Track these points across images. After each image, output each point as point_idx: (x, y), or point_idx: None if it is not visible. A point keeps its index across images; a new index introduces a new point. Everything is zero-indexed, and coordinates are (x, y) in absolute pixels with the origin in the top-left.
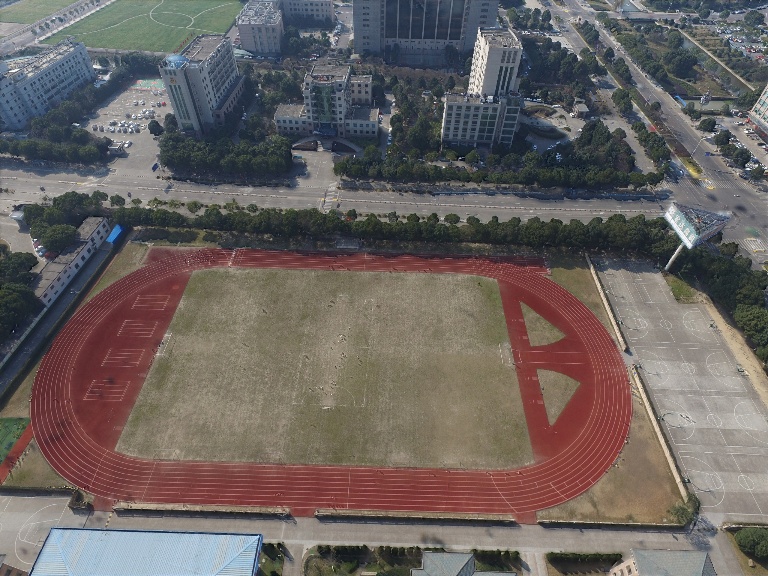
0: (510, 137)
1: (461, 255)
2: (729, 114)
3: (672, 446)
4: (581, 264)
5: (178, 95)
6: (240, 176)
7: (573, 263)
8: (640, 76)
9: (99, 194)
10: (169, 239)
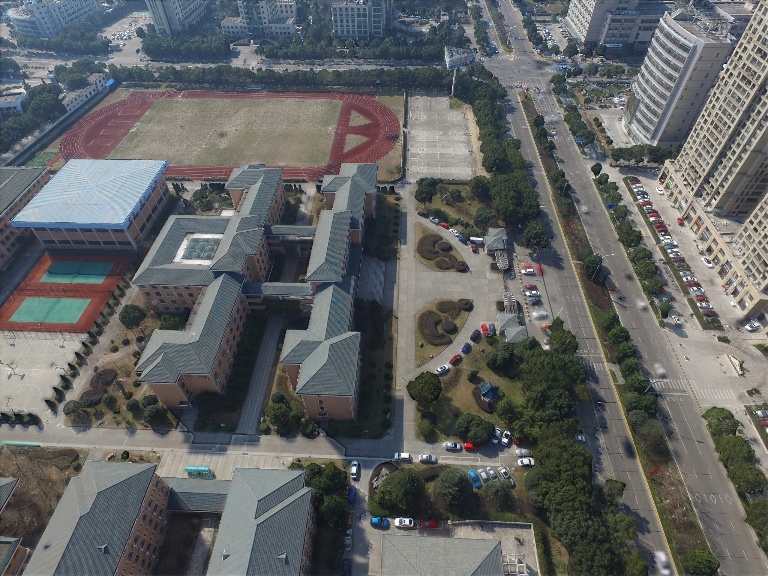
0: (380, 31)
1: (325, 91)
2: (557, 21)
3: (407, 159)
4: (400, 94)
5: (154, 7)
6: (193, 57)
7: (395, 94)
8: (507, 2)
9: (101, 63)
10: (144, 87)
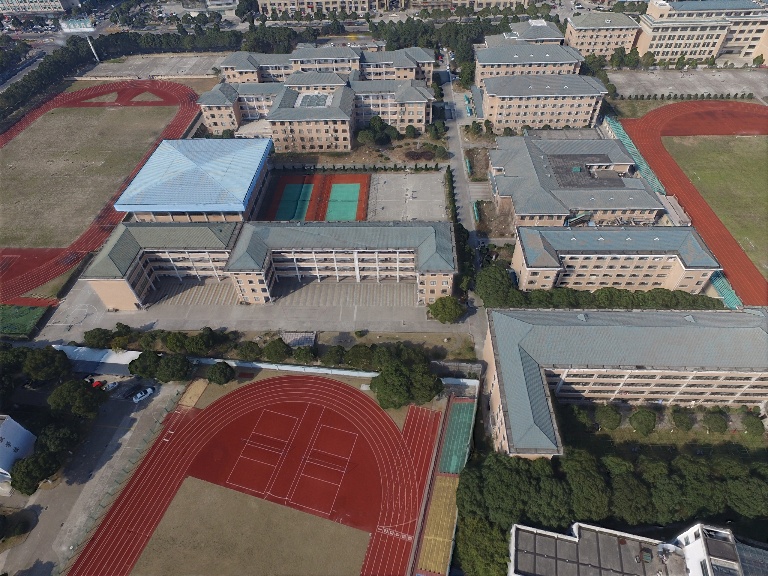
0: None
1: (19, 118)
2: None
3: None
4: (70, 82)
5: None
6: None
7: (67, 84)
8: None
9: None
10: None
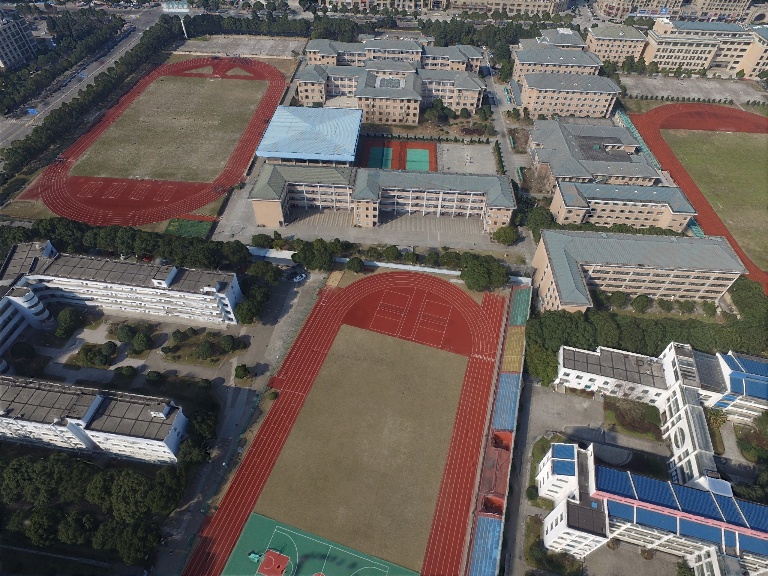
0: (36, 44)
1: (135, 83)
2: None
3: None
4: (168, 55)
5: None
6: None
7: (166, 57)
8: None
9: None
10: (12, 192)
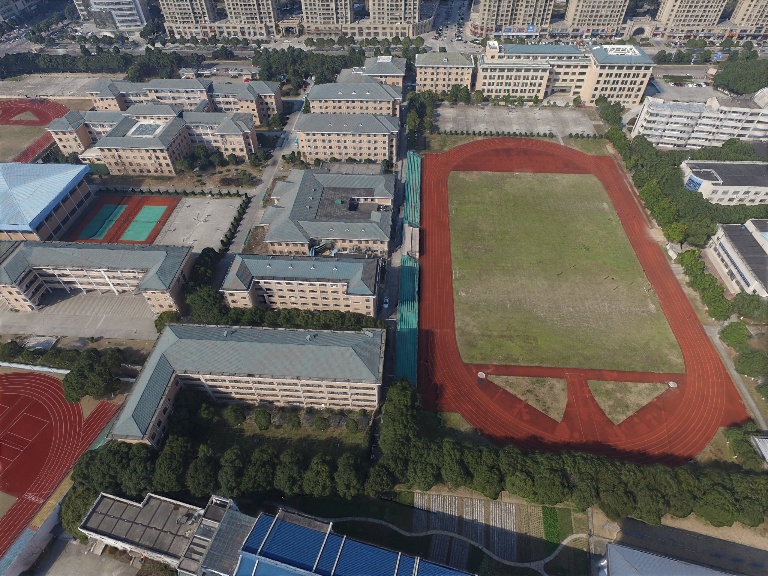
0: None
1: None
2: None
3: None
4: None
5: None
6: None
7: None
8: None
9: None
10: None
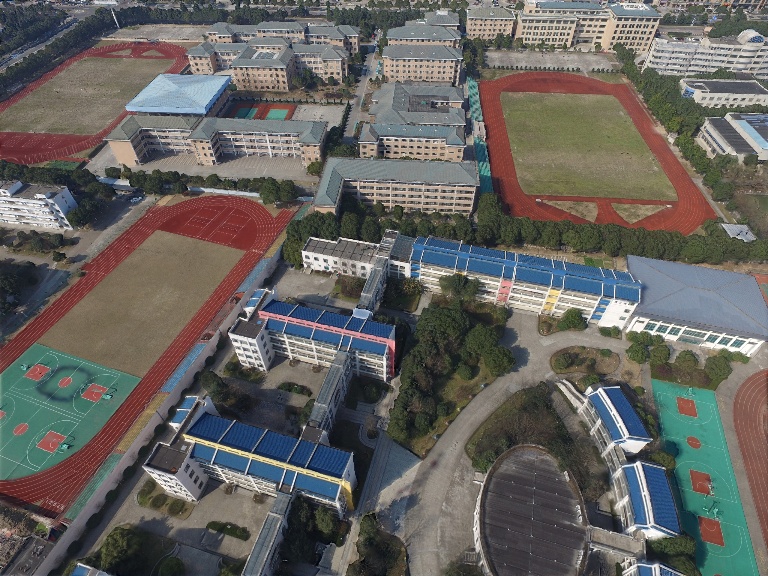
0: None
1: (60, 63)
2: None
3: None
4: (97, 41)
5: None
6: None
7: (95, 42)
8: None
9: None
10: None
